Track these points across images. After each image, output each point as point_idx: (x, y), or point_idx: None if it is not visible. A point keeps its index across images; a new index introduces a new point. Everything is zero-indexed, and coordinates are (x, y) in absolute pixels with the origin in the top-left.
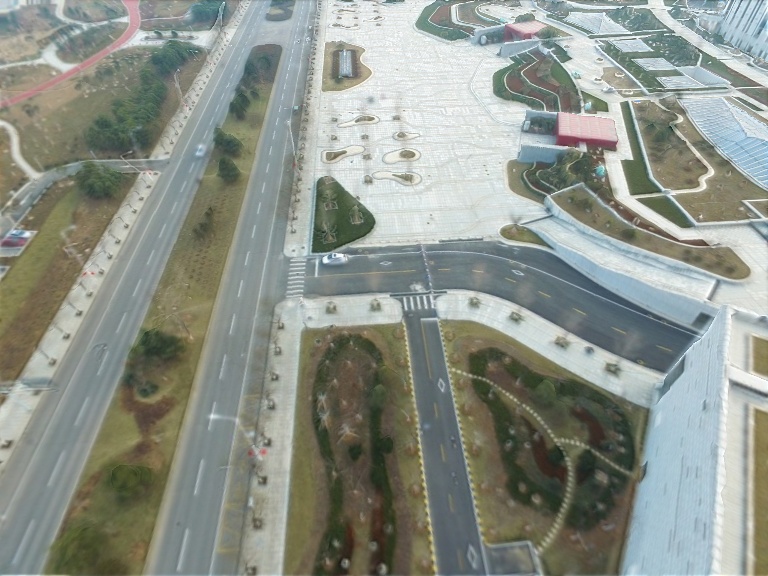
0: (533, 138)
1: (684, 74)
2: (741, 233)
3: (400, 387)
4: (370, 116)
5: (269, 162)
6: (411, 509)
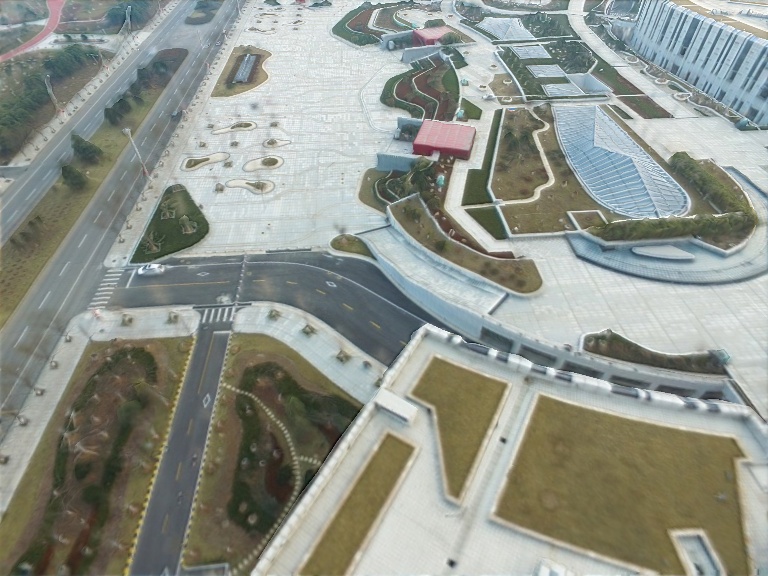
0: (402, 146)
1: (571, 81)
2: (553, 245)
3: (159, 403)
4: (248, 122)
5: (127, 169)
6: (121, 530)
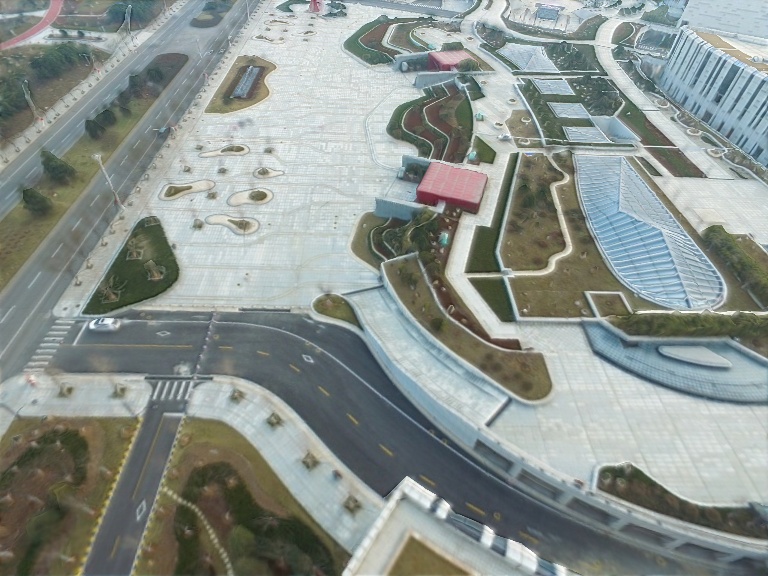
0: (405, 187)
1: (595, 125)
2: (566, 334)
3: (83, 512)
4: (240, 146)
5: (100, 193)
6: None
